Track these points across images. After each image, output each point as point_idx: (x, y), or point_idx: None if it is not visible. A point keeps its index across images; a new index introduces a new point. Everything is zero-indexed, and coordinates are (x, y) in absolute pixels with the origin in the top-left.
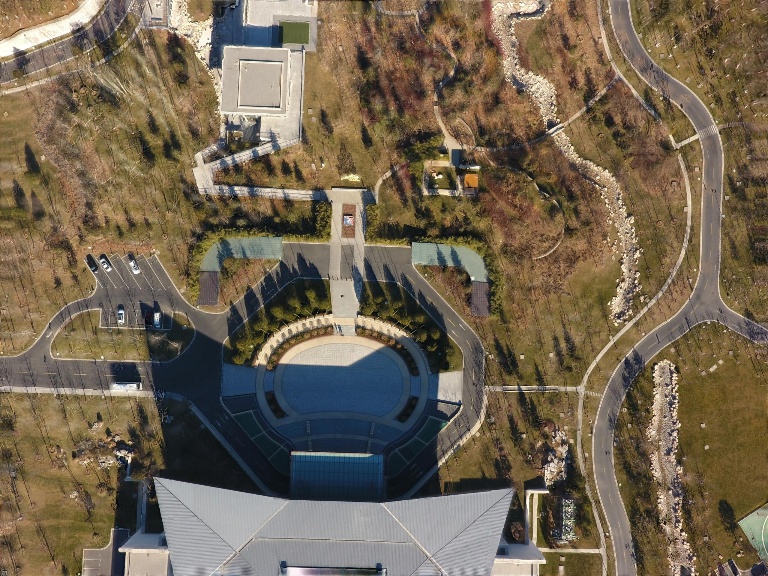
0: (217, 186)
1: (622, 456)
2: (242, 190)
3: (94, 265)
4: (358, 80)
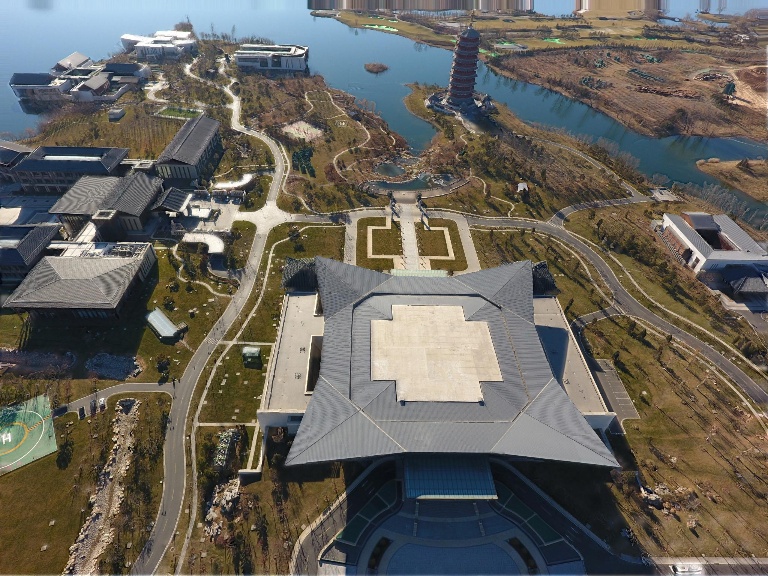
0: None
1: (149, 511)
2: None
3: None
4: None
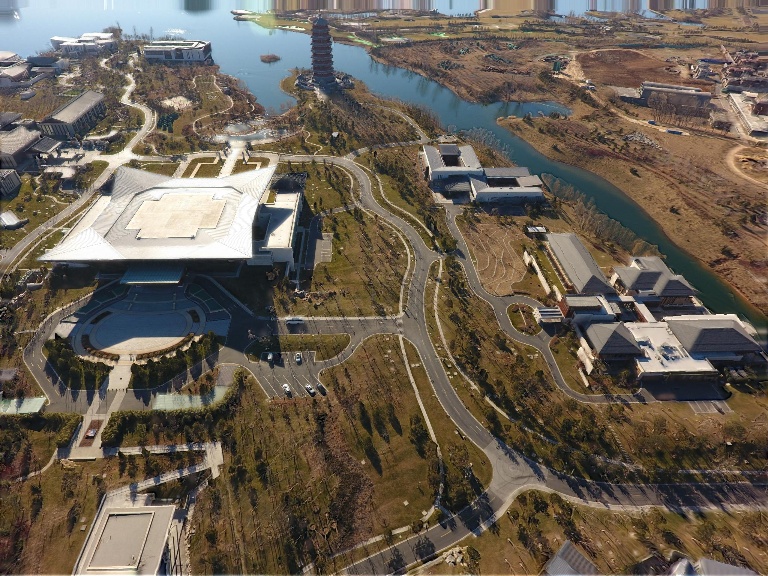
0: None
1: None
2: (181, 449)
3: (319, 388)
4: None
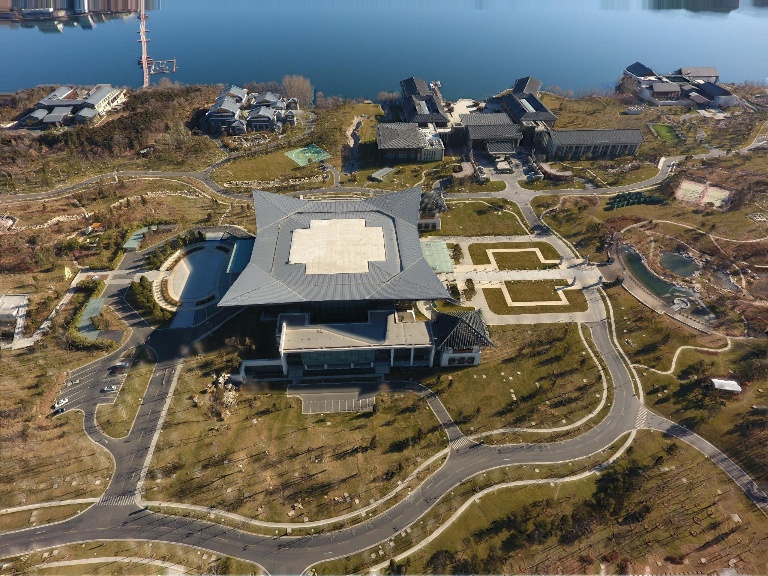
0: (34, 336)
1: None
2: (45, 324)
3: None
4: (4, 276)
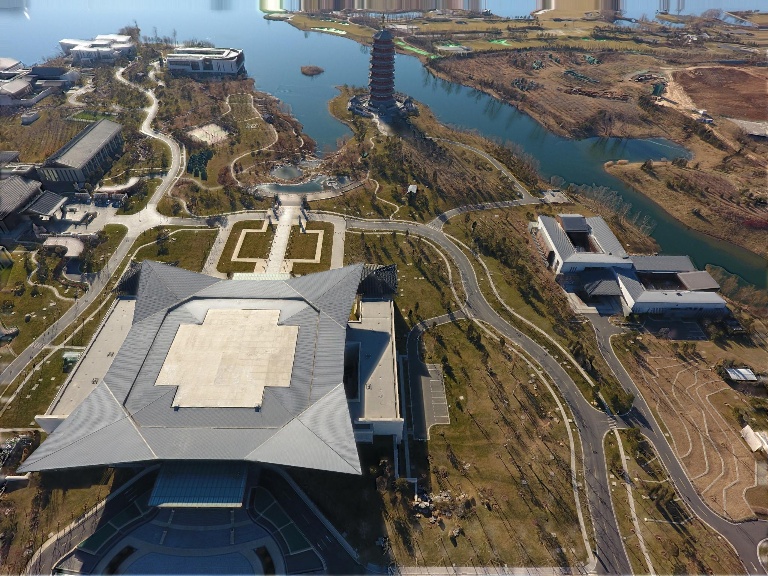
0: None
1: None
2: None
3: None
4: None
